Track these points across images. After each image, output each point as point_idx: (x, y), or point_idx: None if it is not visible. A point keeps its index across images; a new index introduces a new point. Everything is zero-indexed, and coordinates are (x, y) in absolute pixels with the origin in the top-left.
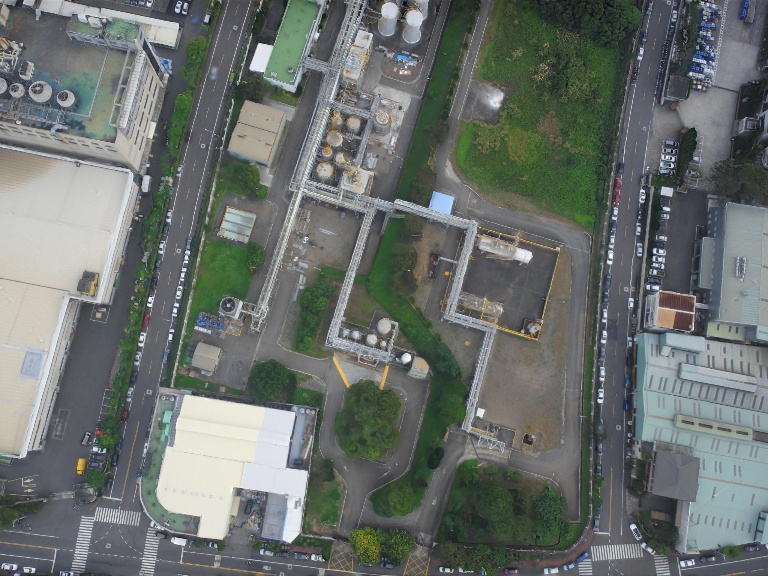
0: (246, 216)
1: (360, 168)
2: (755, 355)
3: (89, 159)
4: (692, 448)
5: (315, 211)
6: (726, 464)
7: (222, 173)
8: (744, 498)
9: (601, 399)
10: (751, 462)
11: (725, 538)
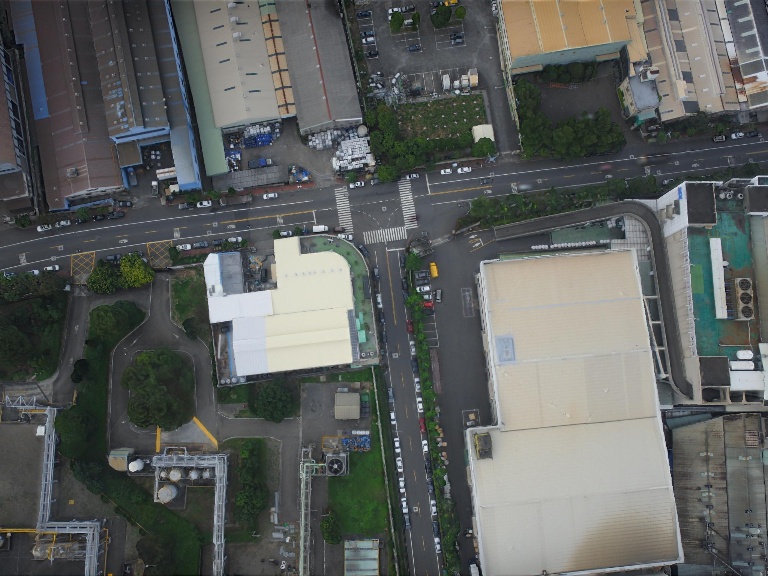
0: (356, 572)
1: None
2: None
3: None
4: None
5: None
6: None
7: None
8: None
9: None
10: None
11: None
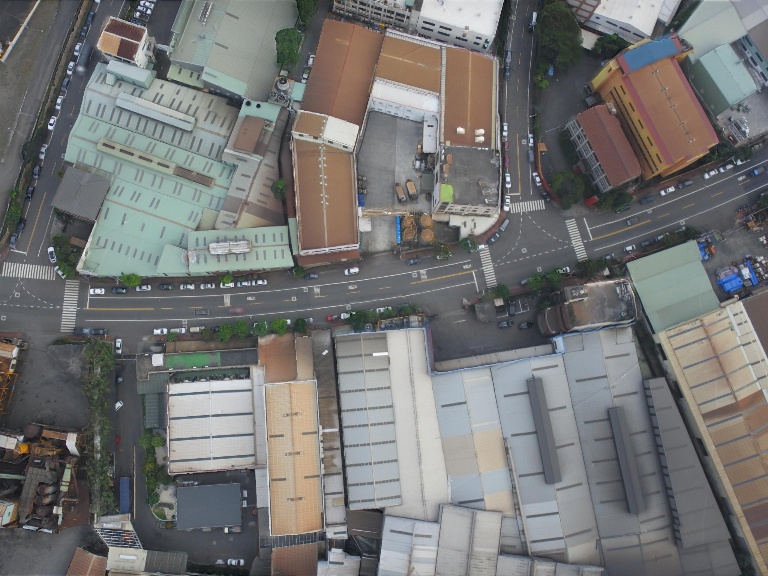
0: None
1: None
2: (208, 102)
3: None
4: (113, 174)
5: None
6: (145, 196)
7: None
8: (154, 229)
9: (51, 125)
10: (173, 199)
11: (130, 267)
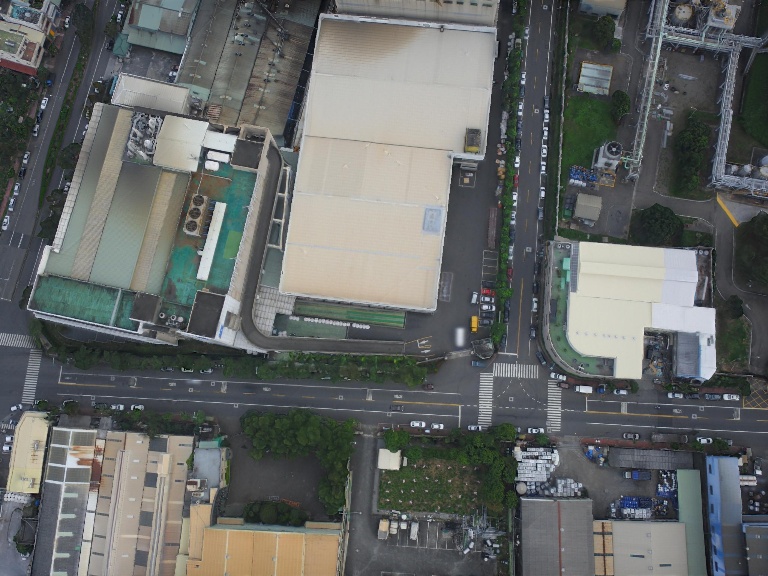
0: (602, 69)
1: (726, 3)
2: None
3: (451, 24)
4: None
5: (671, 58)
6: None
7: (571, 30)
8: None
9: None
10: None
11: None
